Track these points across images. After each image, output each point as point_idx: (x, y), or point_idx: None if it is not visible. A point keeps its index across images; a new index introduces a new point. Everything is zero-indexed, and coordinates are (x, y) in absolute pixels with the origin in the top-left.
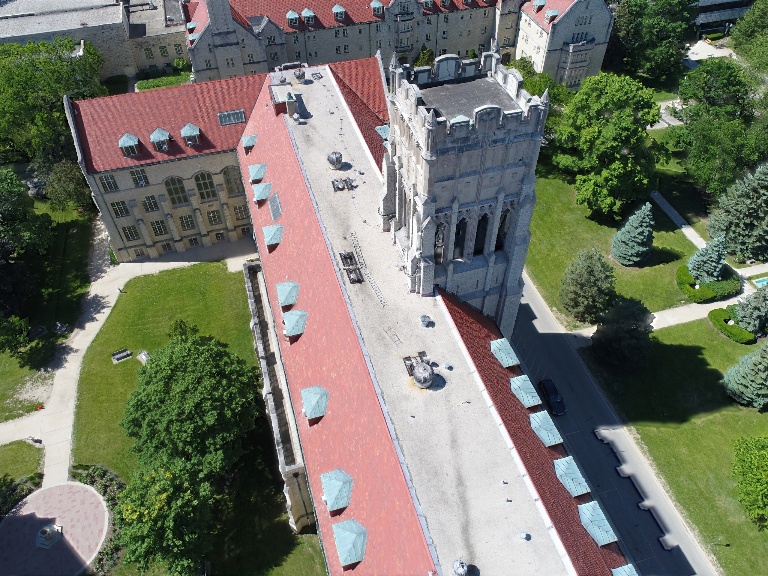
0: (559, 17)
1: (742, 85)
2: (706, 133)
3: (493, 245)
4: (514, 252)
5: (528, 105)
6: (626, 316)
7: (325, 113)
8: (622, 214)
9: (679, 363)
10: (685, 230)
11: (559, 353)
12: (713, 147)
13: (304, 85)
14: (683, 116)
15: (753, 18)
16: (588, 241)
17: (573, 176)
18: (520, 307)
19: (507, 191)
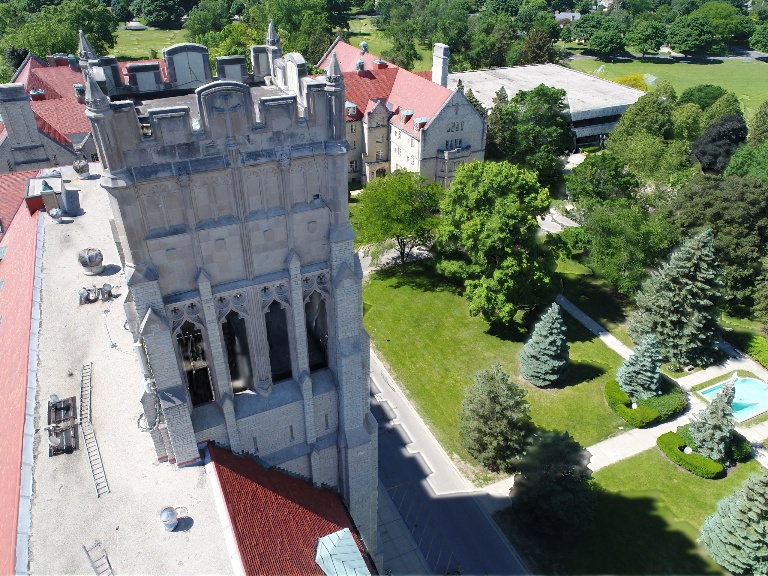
0: (428, 123)
1: (631, 176)
2: (605, 224)
3: (303, 360)
4: (342, 369)
5: (304, 85)
6: (551, 458)
7: (104, 208)
8: (527, 325)
9: (636, 519)
10: (604, 338)
11: (468, 524)
12: (616, 239)
13: (87, 180)
14: (576, 215)
15: (624, 128)
16: (490, 361)
17: (464, 287)
18: (408, 459)
19: (305, 257)
